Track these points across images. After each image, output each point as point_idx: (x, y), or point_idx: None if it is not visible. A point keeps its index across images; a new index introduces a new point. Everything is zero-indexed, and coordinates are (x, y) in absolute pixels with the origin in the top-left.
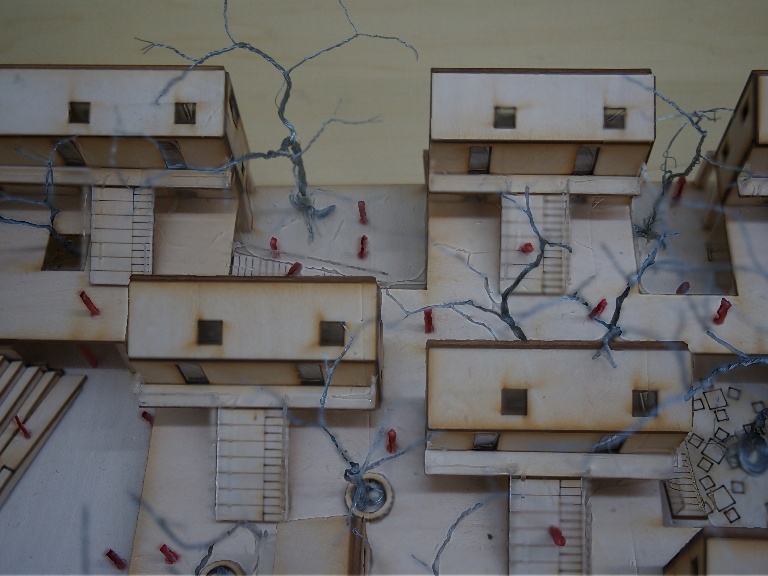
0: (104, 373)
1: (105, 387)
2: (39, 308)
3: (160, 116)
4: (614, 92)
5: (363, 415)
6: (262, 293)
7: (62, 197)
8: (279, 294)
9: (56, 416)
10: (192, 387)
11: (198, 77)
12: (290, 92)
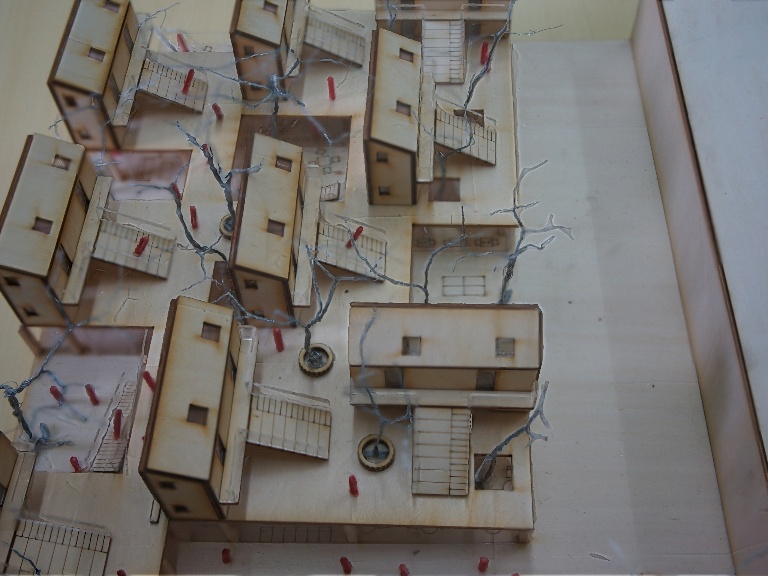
0: None
1: None
2: None
3: None
4: (42, 157)
5: None
6: (173, 371)
7: None
8: (176, 360)
9: None
10: (226, 463)
11: None
12: None
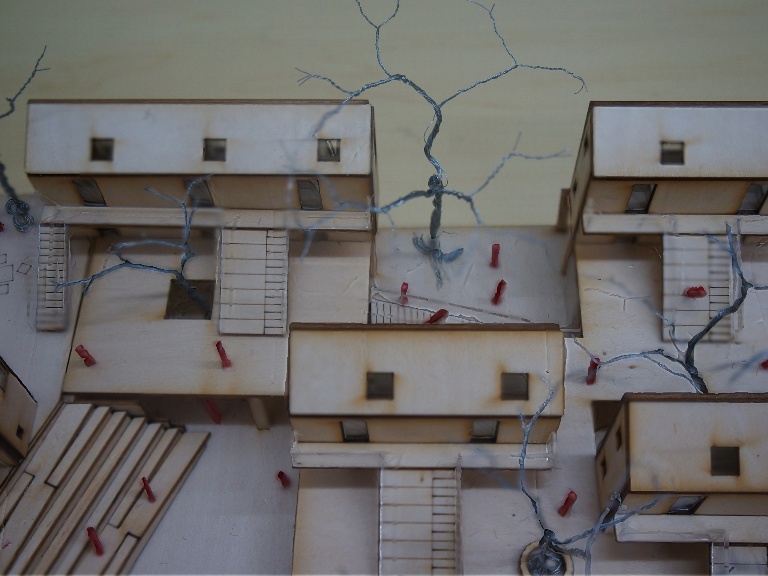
0: (228, 429)
1: (230, 445)
2: (165, 360)
3: (302, 153)
4: None
5: (529, 475)
6: (437, 342)
7: (183, 240)
8: (456, 343)
9: (181, 477)
10: (350, 445)
11: (342, 112)
12: (439, 127)
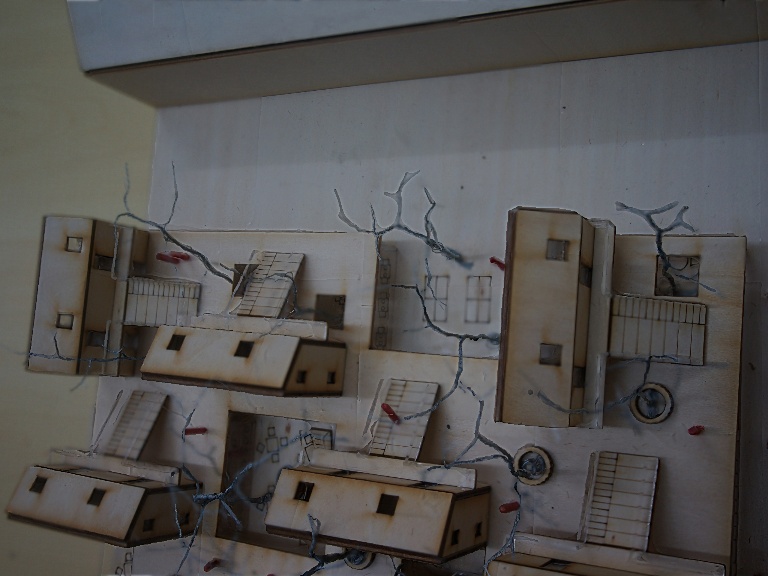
0: None
1: None
2: None
3: None
4: None
5: None
6: None
7: None
8: None
9: None
10: None
11: None
12: None
